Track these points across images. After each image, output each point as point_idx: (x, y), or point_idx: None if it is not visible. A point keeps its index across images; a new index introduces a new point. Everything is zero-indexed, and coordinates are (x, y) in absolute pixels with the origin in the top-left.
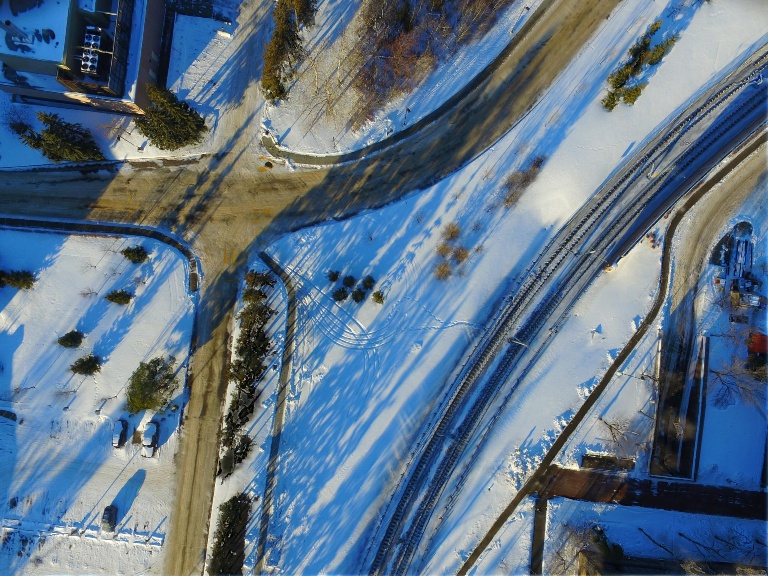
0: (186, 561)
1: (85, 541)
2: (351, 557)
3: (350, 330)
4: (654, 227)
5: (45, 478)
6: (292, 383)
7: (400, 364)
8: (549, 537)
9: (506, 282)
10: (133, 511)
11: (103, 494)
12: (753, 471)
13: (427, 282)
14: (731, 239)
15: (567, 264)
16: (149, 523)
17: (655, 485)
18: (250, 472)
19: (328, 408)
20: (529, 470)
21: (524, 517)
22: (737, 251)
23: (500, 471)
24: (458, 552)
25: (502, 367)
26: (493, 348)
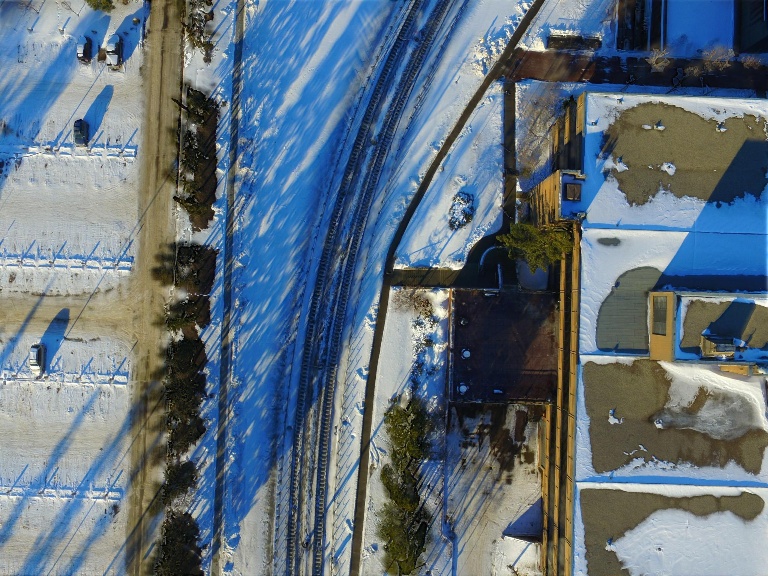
0: (160, 170)
1: (60, 158)
2: (323, 157)
3: None
4: None
5: (16, 102)
6: None
7: None
8: (520, 116)
9: None
10: (104, 126)
11: (73, 112)
12: (724, 39)
13: None
14: None
15: None
16: (121, 137)
17: (624, 61)
18: (215, 77)
19: (287, 11)
20: (494, 54)
21: (493, 100)
22: None
23: (466, 63)
24: (430, 145)
25: None
26: None
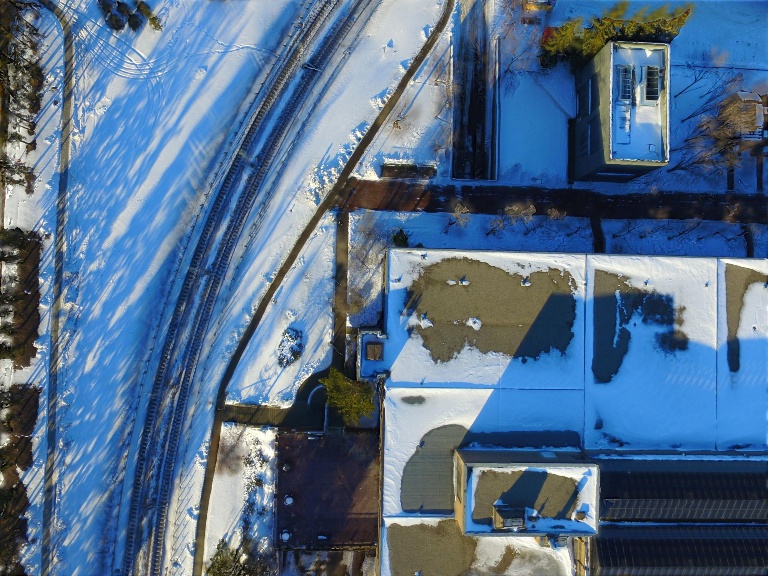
0: None
1: None
2: (153, 289)
3: (131, 60)
4: None
5: None
6: (75, 118)
7: (186, 90)
8: (352, 247)
9: (293, 7)
10: None
11: None
12: (558, 167)
13: (206, 6)
14: None
15: None
16: None
17: (459, 190)
18: (38, 209)
19: (115, 140)
20: (327, 184)
21: (326, 231)
22: None
23: (300, 191)
24: (263, 275)
25: (298, 93)
26: (287, 75)
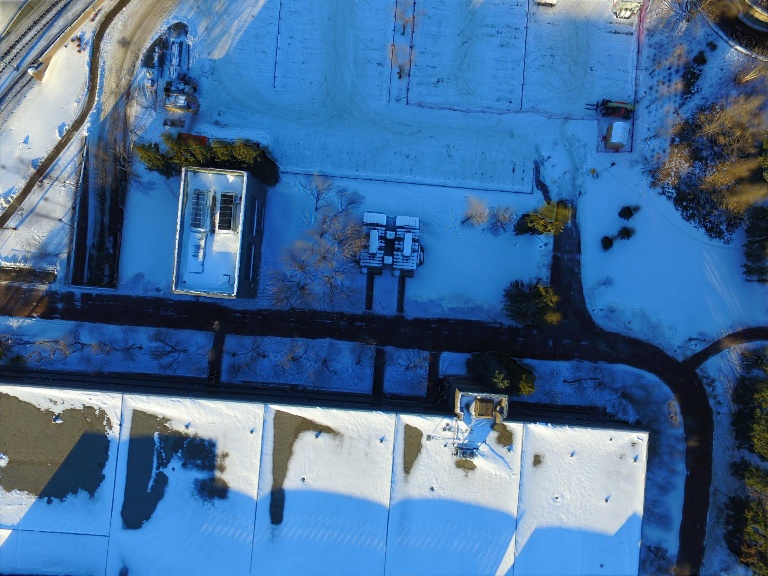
0: None
1: None
2: None
3: None
4: (79, 31)
5: None
6: None
7: None
8: None
9: None
10: None
11: None
12: None
13: None
14: (165, 41)
15: (5, 79)
16: None
17: (78, 297)
18: None
19: None
20: None
21: None
22: (171, 52)
23: None
24: None
25: None
26: None
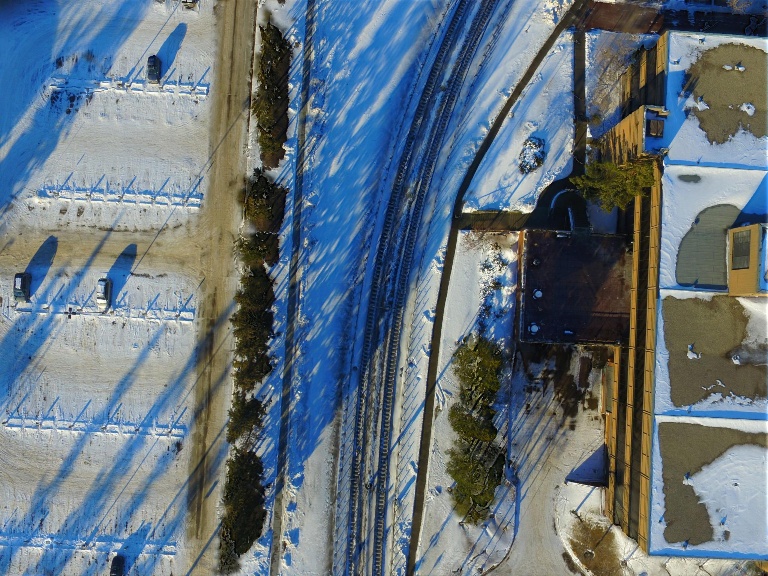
0: (232, 108)
1: (131, 94)
2: (394, 100)
3: None
4: None
5: (89, 37)
6: None
7: None
8: (590, 64)
9: None
10: (177, 64)
11: (146, 48)
12: None
13: None
14: None
15: None
16: (193, 75)
17: (692, 15)
18: (289, 18)
19: None
20: (565, 4)
21: (563, 49)
22: None
23: (536, 13)
24: (500, 91)
25: None
26: None
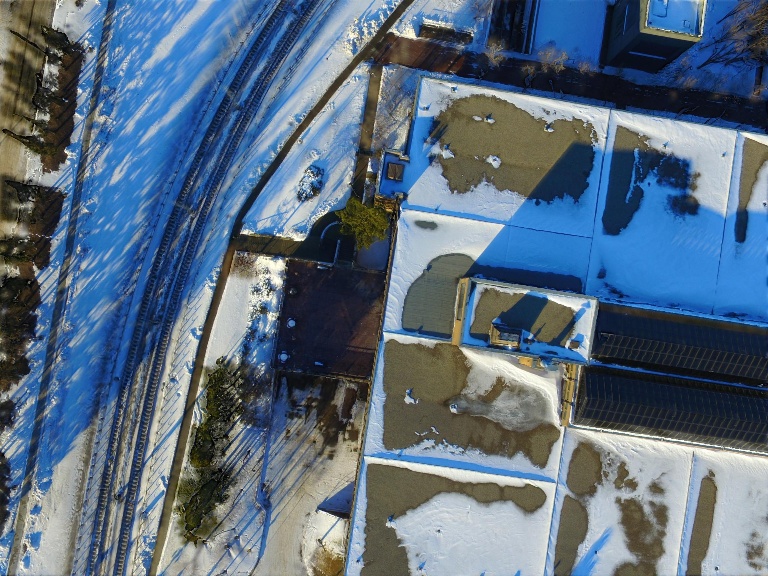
0: (18, 107)
1: None
2: (185, 115)
3: None
4: None
5: None
6: None
7: None
8: (382, 98)
9: None
10: None
11: None
12: (591, 50)
13: None
14: None
15: None
16: None
17: None
18: (85, 22)
19: None
20: (365, 35)
21: (358, 80)
22: None
23: (338, 41)
24: (293, 116)
25: None
26: None
